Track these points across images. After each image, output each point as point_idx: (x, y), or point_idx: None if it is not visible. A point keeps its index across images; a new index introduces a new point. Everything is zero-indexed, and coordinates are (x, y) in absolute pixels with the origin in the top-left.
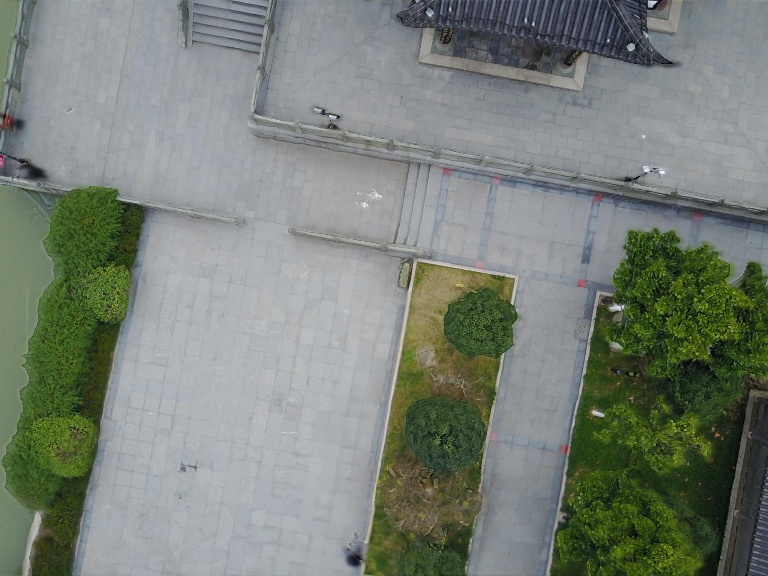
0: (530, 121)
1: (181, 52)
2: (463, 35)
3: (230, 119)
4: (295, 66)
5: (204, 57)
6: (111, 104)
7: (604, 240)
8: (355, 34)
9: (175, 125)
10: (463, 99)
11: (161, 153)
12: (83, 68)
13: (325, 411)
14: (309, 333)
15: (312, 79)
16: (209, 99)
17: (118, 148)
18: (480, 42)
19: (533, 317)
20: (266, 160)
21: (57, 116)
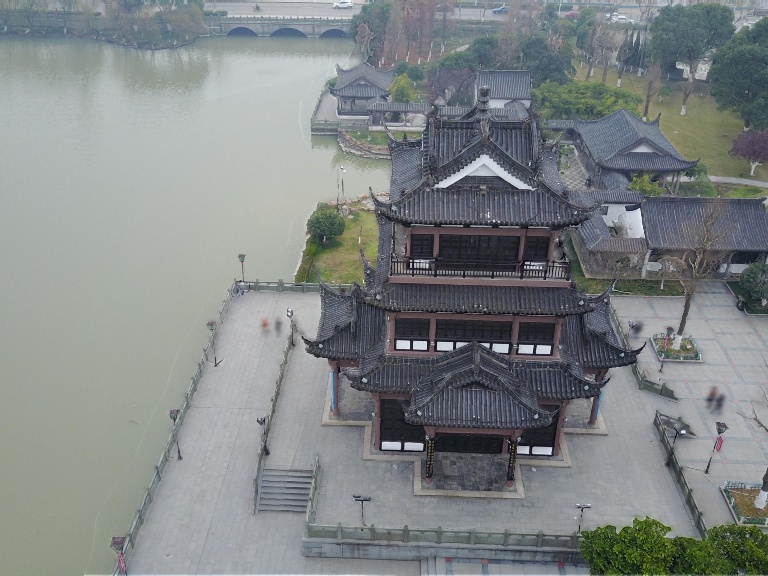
0: (497, 518)
1: (251, 517)
2: (440, 479)
3: (286, 550)
4: (333, 505)
5: (267, 518)
6: (199, 550)
7: None
8: (370, 486)
9: (246, 557)
10: (449, 511)
11: (235, 574)
12: (181, 532)
13: None
14: None
15: (345, 511)
16: (271, 540)
17: (203, 575)
18: (451, 481)
19: None
20: (315, 570)
21: (158, 560)
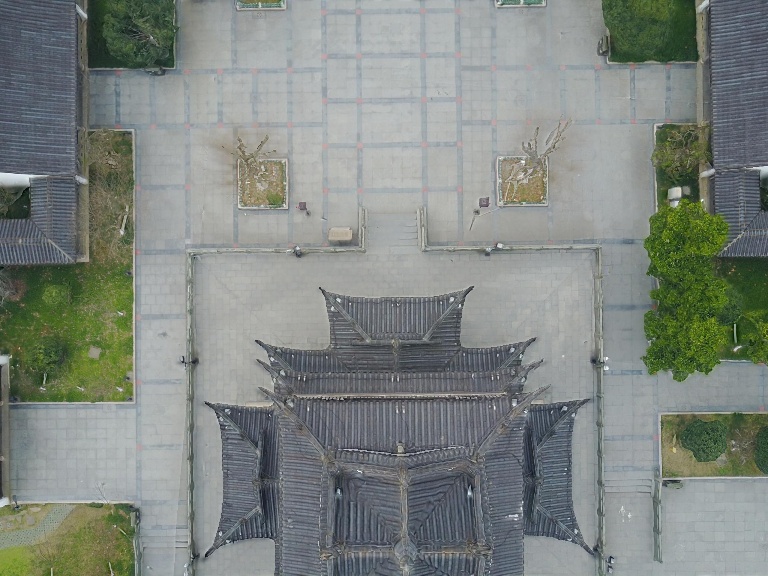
0: None
1: None
2: None
3: None
4: None
5: None
6: None
7: (626, 364)
8: (535, 546)
9: None
10: None
11: None
12: None
13: (765, 516)
14: (718, 536)
15: (568, 568)
16: None
17: None
18: None
19: (682, 399)
20: None
21: None
